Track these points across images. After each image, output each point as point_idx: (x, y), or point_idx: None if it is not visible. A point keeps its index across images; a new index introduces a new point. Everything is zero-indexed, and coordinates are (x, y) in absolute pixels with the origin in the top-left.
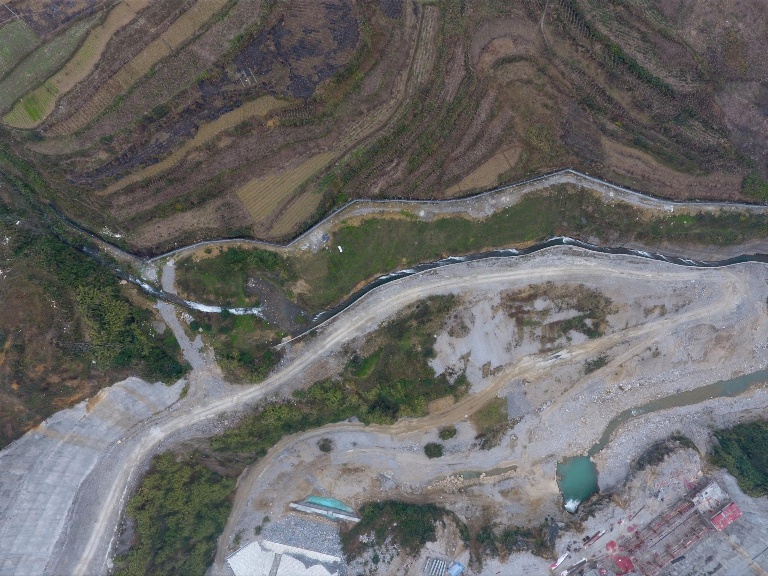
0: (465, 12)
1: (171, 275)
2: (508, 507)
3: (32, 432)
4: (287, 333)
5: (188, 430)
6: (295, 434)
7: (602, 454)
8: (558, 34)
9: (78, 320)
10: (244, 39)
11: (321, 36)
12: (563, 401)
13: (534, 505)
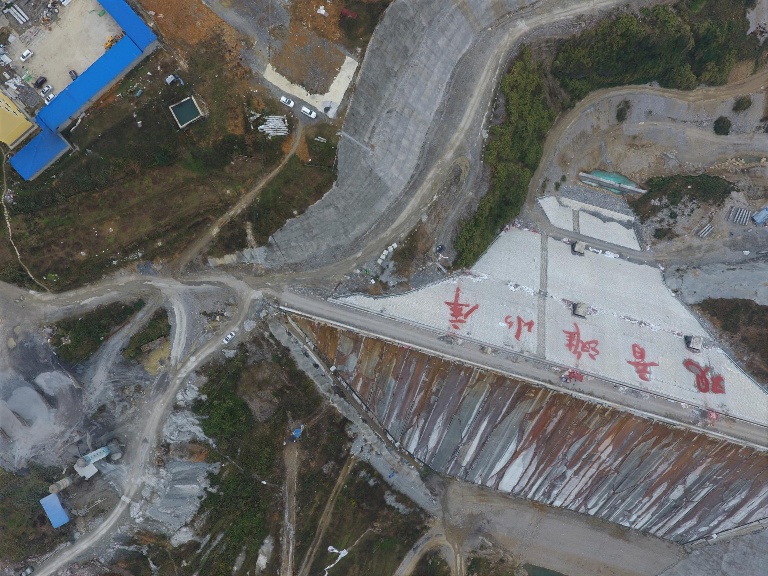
0: None
1: None
2: None
3: None
4: None
5: (550, 26)
6: (601, 92)
7: None
8: None
9: None
10: None
11: None
12: None
13: None
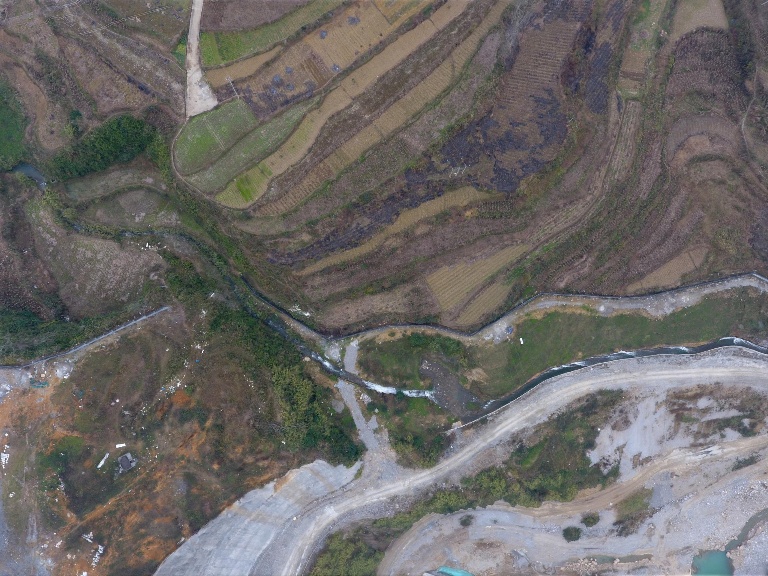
0: (665, 108)
1: (353, 355)
2: None
3: (226, 511)
4: (458, 418)
5: (361, 511)
6: None
7: (740, 551)
8: (759, 137)
9: (271, 400)
10: (454, 130)
11: (528, 130)
12: (705, 494)
13: None
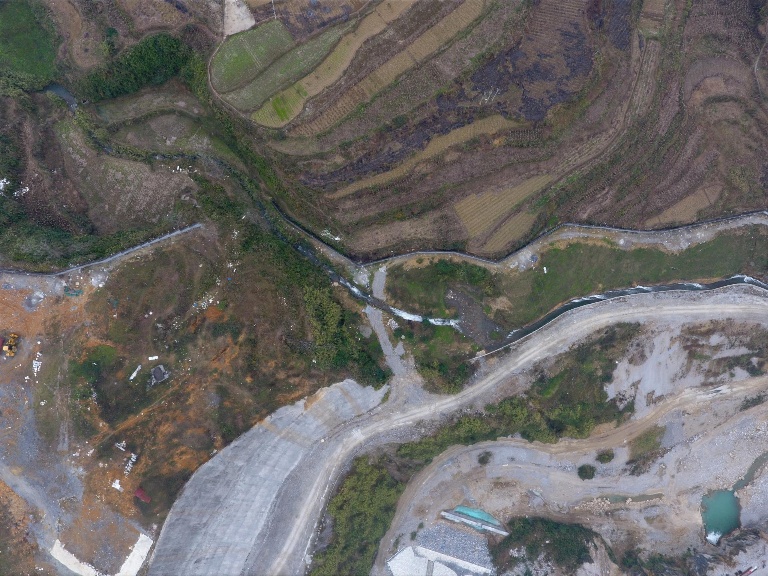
0: (683, 49)
1: (382, 281)
2: (652, 534)
3: (258, 425)
4: (482, 347)
5: (387, 435)
6: (460, 445)
7: (747, 490)
8: None
9: (303, 319)
10: (484, 58)
11: (555, 62)
12: (714, 435)
13: (677, 534)
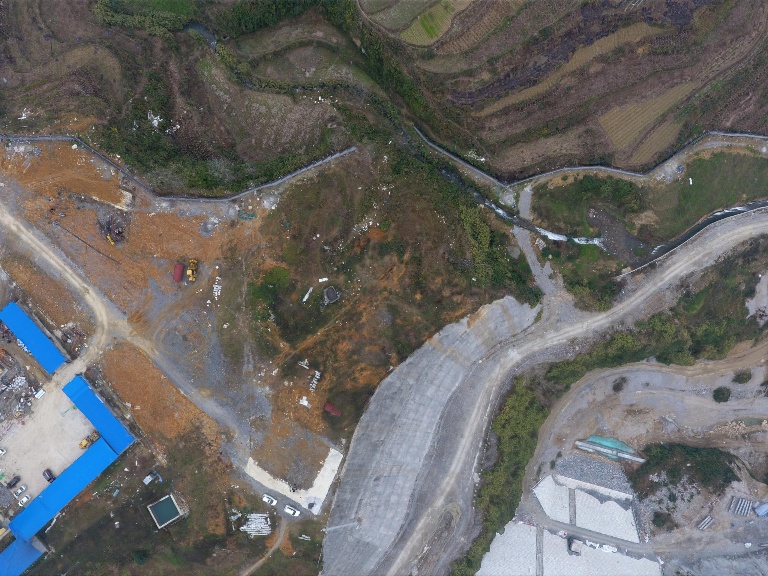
0: None
1: (527, 201)
2: None
3: (428, 343)
4: (627, 264)
5: (543, 353)
6: (596, 371)
7: None
8: None
9: (461, 237)
10: None
11: None
12: None
13: None
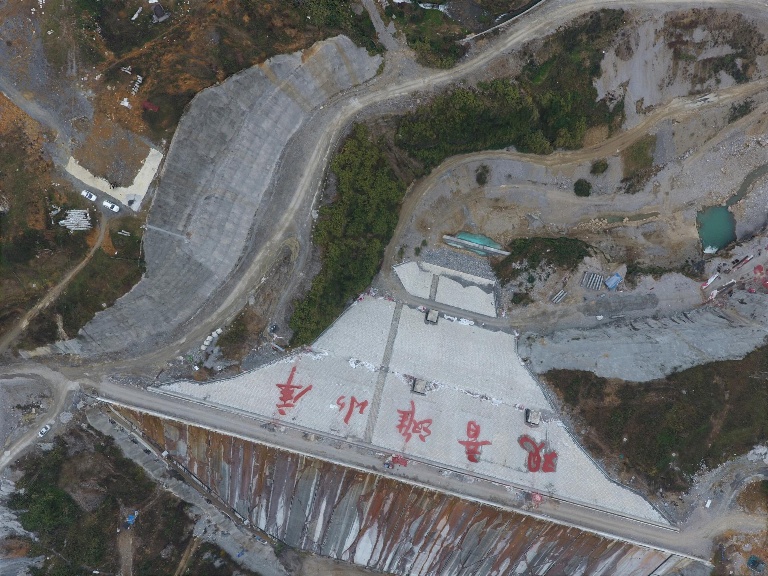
0: None
1: None
2: (650, 249)
3: (258, 67)
4: (471, 31)
5: (384, 104)
6: (457, 158)
7: (740, 204)
8: None
9: None
10: None
11: None
12: (705, 150)
13: (675, 248)
